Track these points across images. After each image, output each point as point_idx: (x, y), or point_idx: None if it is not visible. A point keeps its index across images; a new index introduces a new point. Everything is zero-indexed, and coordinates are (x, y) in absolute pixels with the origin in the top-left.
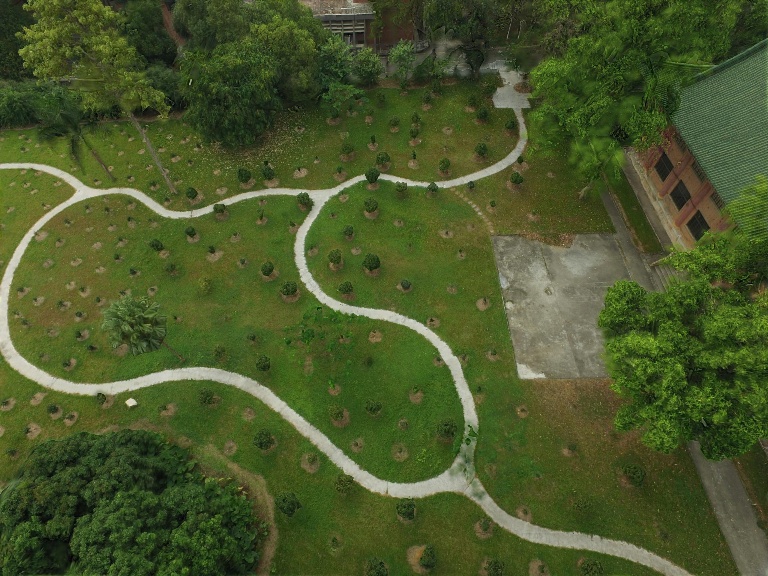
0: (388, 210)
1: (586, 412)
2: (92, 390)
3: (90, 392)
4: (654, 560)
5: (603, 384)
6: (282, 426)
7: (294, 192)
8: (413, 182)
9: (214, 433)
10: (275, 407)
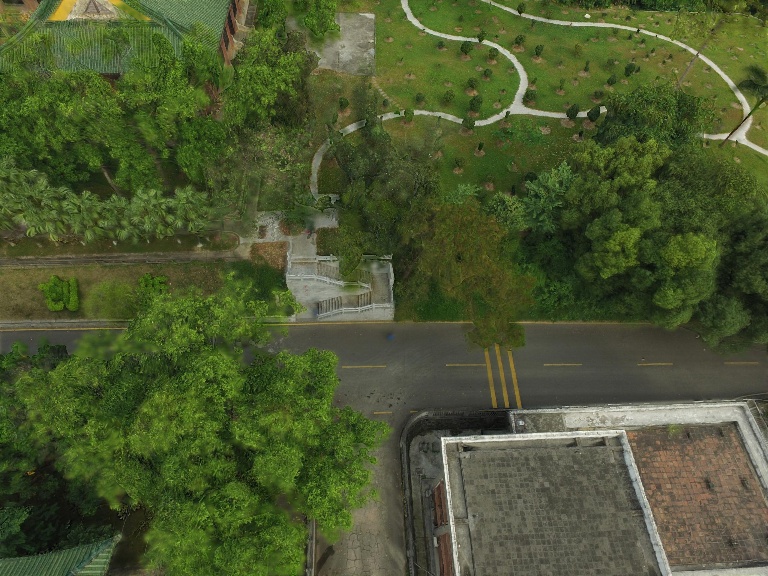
0: (458, 93)
1: (343, 2)
2: (614, 25)
3: (615, 25)
4: None
5: None
6: (502, 2)
7: (543, 113)
8: (437, 115)
9: (536, 3)
10: (509, 8)
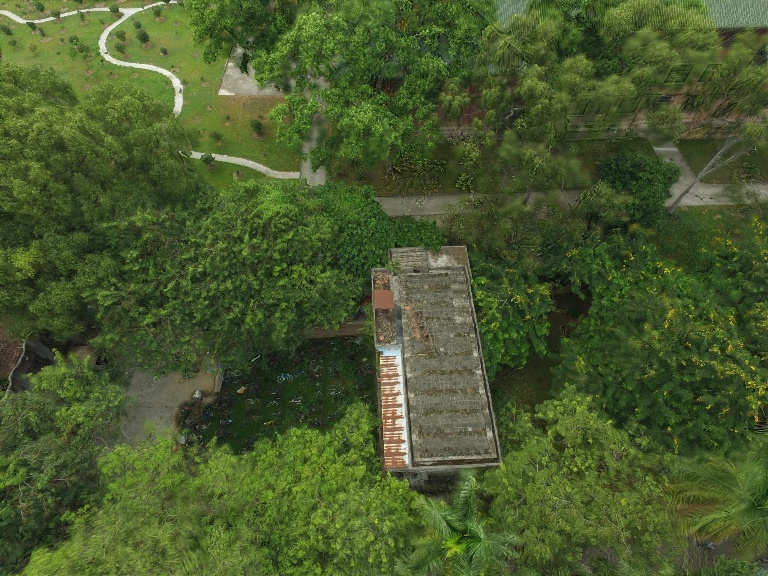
0: (172, 18)
1: (250, 109)
2: None
3: None
4: (254, 165)
5: (268, 97)
6: None
7: None
8: None
9: None
10: None
